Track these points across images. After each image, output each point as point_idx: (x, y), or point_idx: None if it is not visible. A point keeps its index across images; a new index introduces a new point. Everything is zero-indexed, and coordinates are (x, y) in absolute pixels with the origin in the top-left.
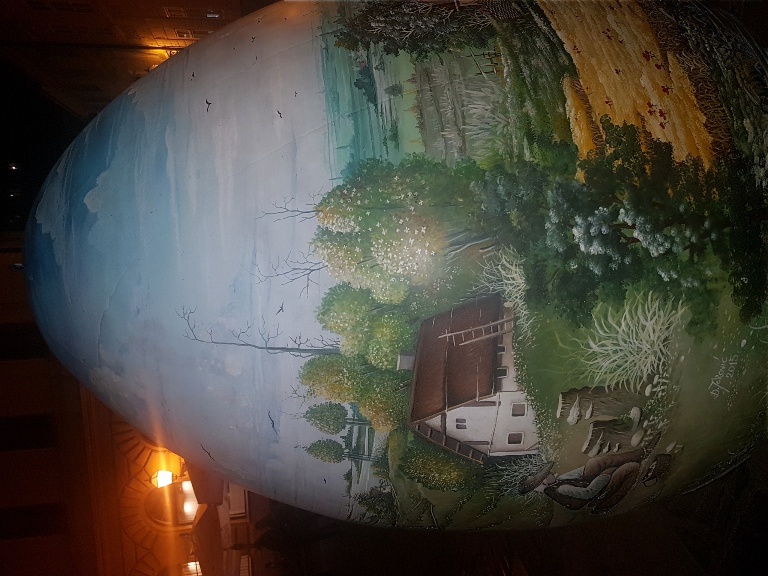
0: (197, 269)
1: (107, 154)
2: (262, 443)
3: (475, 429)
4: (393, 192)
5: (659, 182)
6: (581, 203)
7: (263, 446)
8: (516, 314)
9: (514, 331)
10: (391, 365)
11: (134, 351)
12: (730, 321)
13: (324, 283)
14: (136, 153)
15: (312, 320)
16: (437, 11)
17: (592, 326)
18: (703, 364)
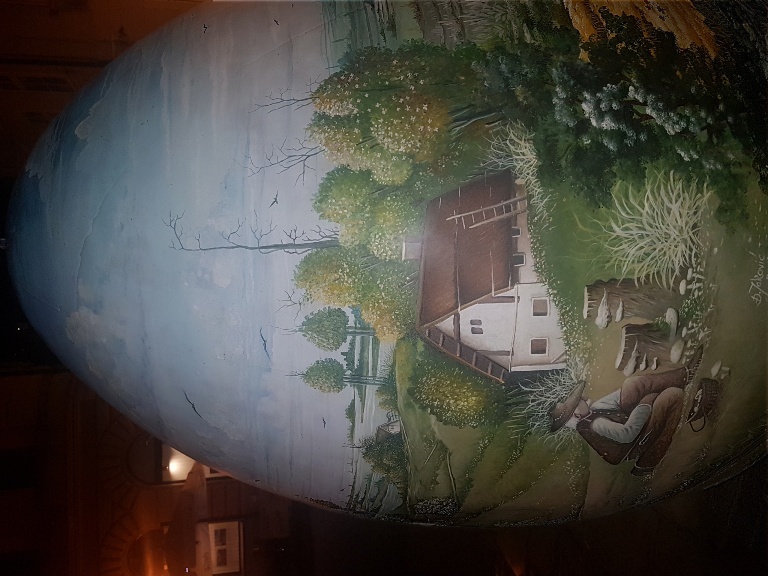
0: (187, 171)
1: (102, 87)
2: (253, 375)
3: (493, 334)
4: (392, 74)
5: (666, 64)
6: (588, 80)
7: (254, 379)
8: (529, 192)
9: (528, 211)
10: (395, 255)
11: (115, 277)
12: (761, 212)
13: (321, 168)
14: (131, 79)
15: (308, 209)
16: None
17: (613, 206)
18: (739, 260)
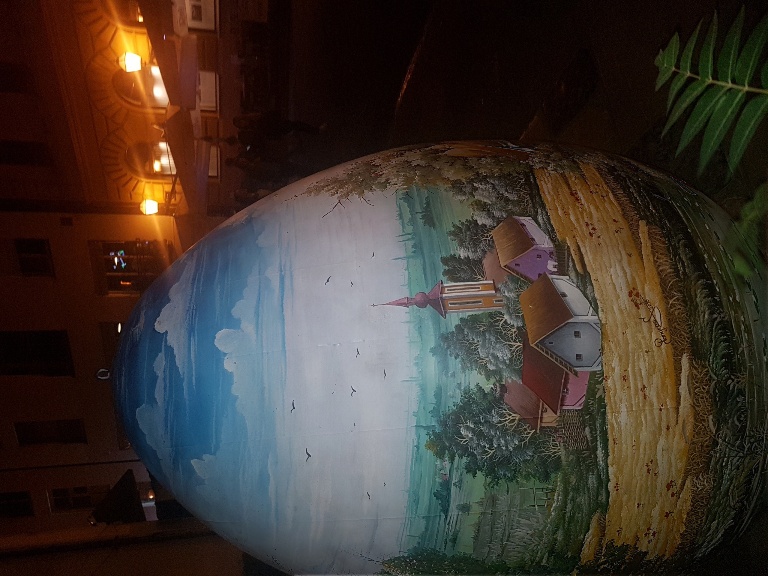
0: (287, 551)
1: (212, 442)
2: None
3: None
4: (441, 568)
5: (626, 572)
6: None
7: None
8: None
9: None
10: None
11: None
12: None
13: None
14: (241, 461)
15: None
16: (520, 429)
17: None
18: None
